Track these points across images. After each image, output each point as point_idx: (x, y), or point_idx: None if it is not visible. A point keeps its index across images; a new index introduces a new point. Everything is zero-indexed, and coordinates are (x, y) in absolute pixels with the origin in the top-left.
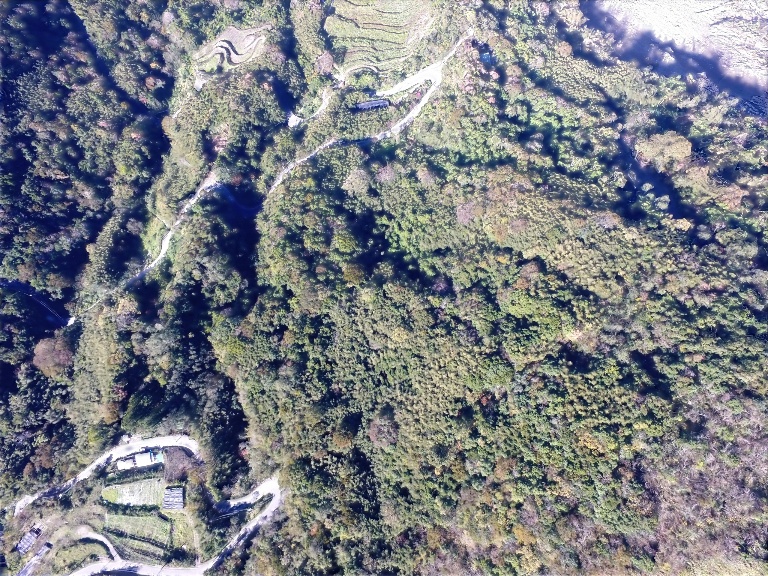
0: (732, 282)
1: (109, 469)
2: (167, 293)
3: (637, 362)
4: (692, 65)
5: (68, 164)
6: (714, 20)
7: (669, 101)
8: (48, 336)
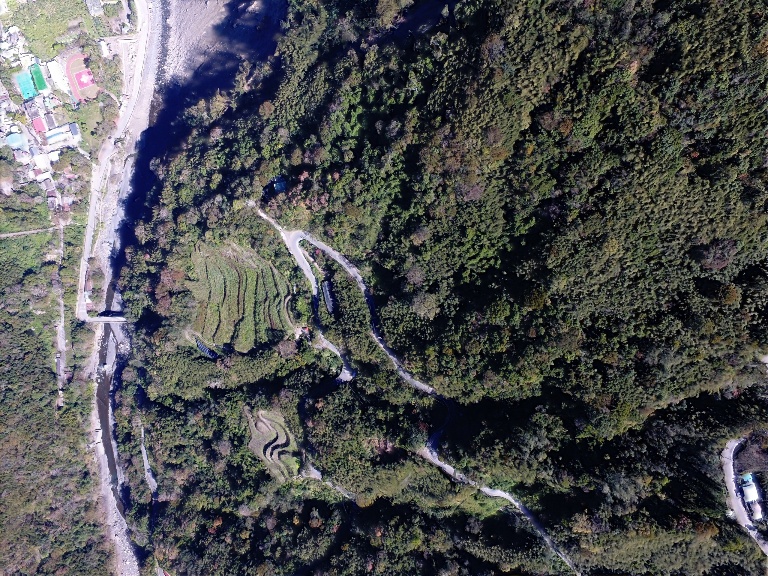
0: None
1: (763, 527)
2: (565, 484)
3: (672, 2)
4: None
5: None
6: None
7: (319, 1)
8: None
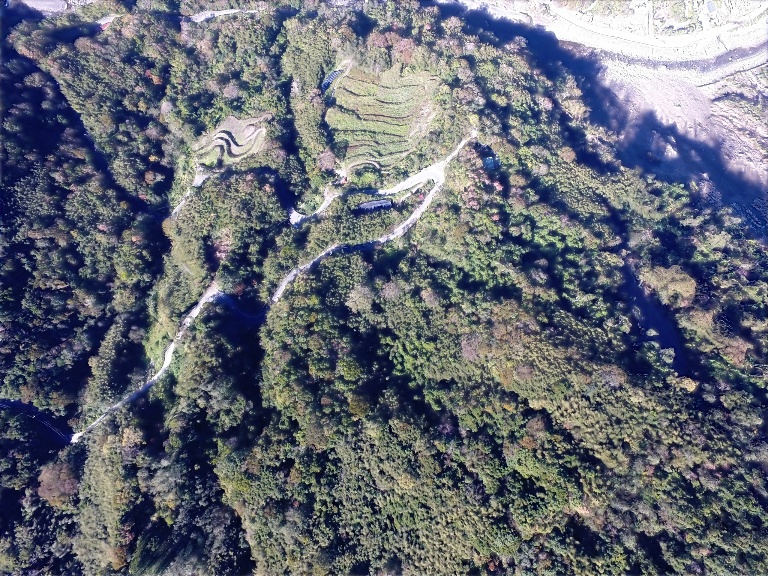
0: (737, 460)
1: None
2: (172, 424)
3: (644, 549)
4: (694, 160)
5: (68, 273)
6: (715, 95)
7: (672, 213)
8: (52, 456)
